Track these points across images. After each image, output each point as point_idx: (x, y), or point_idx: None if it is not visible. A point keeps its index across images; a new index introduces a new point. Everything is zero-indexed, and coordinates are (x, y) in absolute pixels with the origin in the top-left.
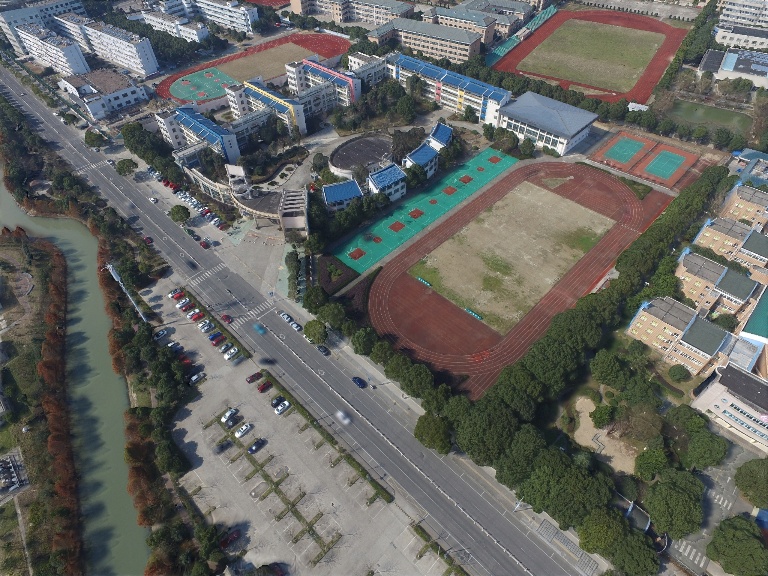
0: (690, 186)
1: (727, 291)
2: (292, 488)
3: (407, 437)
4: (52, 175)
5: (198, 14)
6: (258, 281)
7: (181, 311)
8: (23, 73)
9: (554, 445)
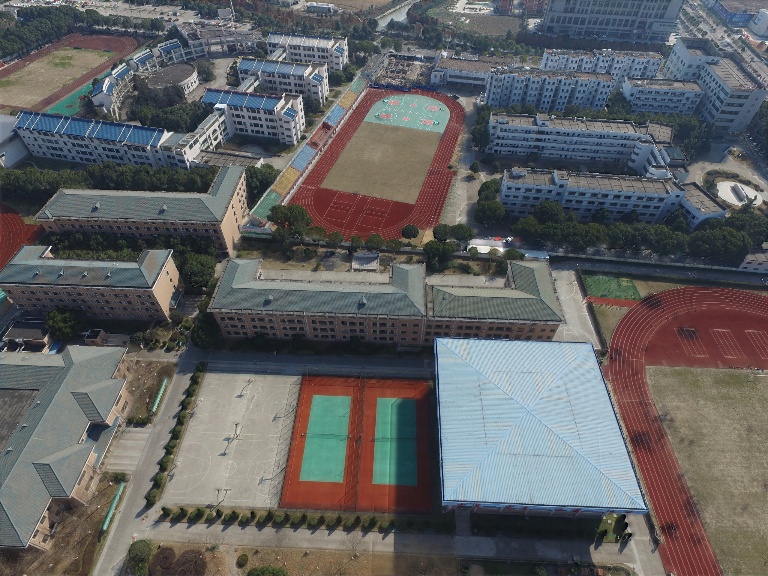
0: None
1: None
2: None
3: None
4: None
5: None
6: None
7: None
8: None
9: None
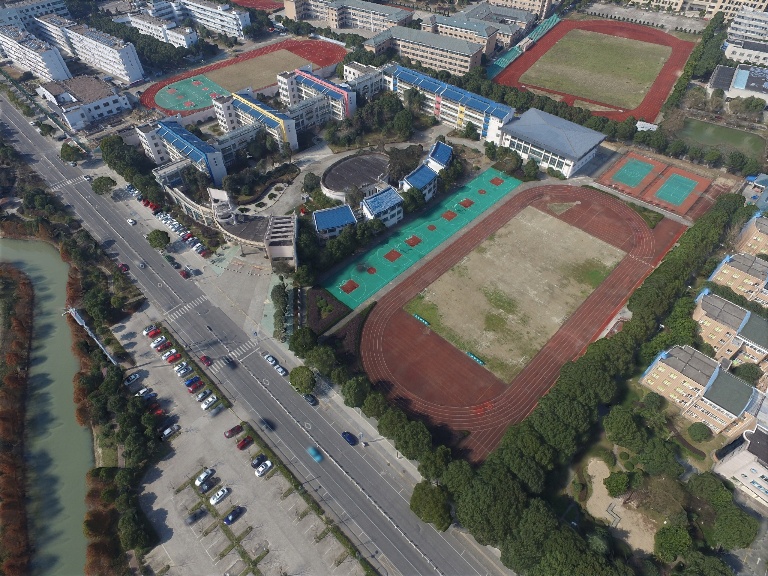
0: (705, 216)
1: (750, 339)
2: (272, 568)
3: (402, 505)
4: (24, 192)
5: (188, 17)
6: (241, 317)
7: (156, 351)
8: (0, 77)
9: (565, 517)
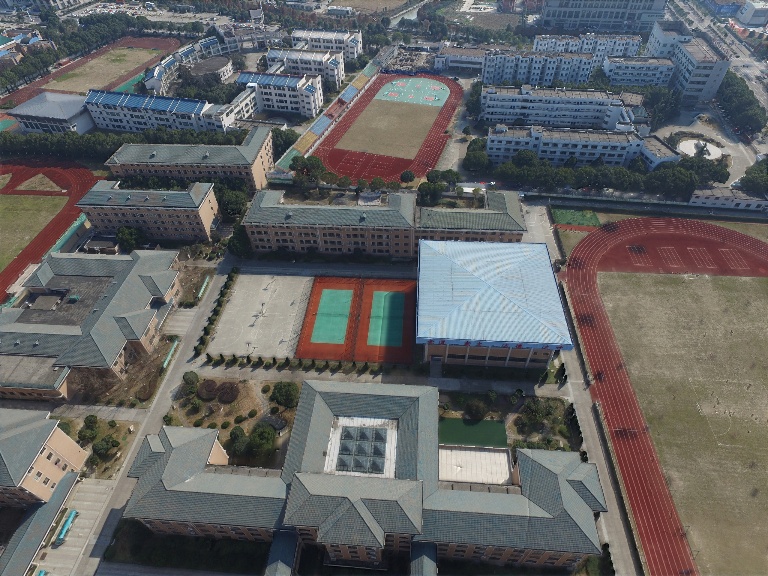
0: None
1: None
2: (186, 18)
3: None
4: None
5: None
6: None
7: None
8: None
9: None
